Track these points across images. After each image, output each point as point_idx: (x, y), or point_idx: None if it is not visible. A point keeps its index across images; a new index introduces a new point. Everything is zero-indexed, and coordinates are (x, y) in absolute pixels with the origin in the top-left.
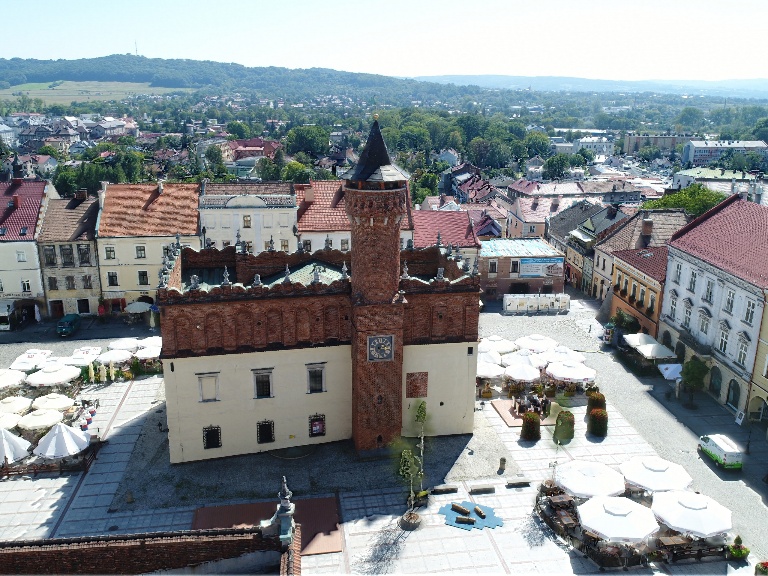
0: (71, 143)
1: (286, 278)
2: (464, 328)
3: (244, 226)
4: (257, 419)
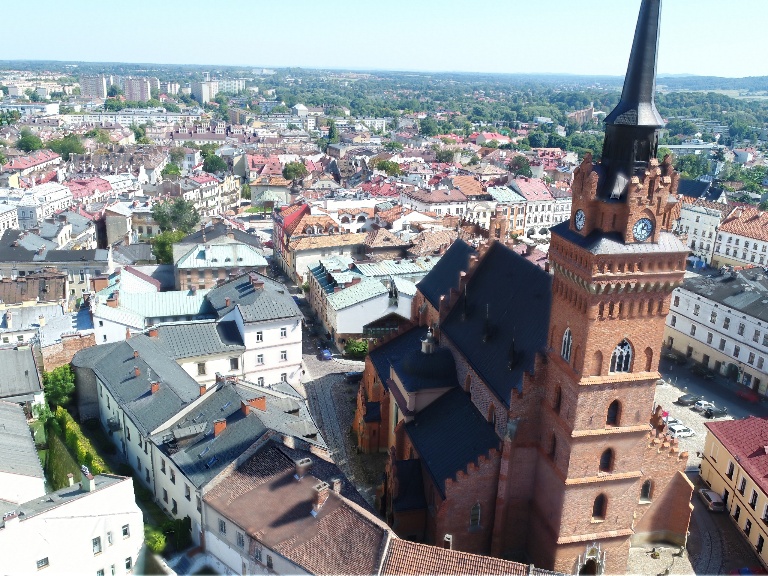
0: None
1: None
2: None
3: (697, 221)
4: None
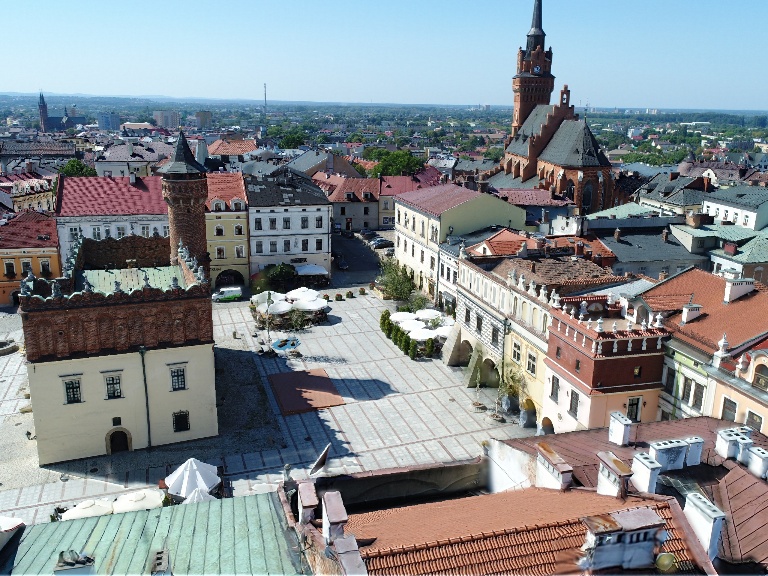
0: None
1: None
2: None
3: None
4: None
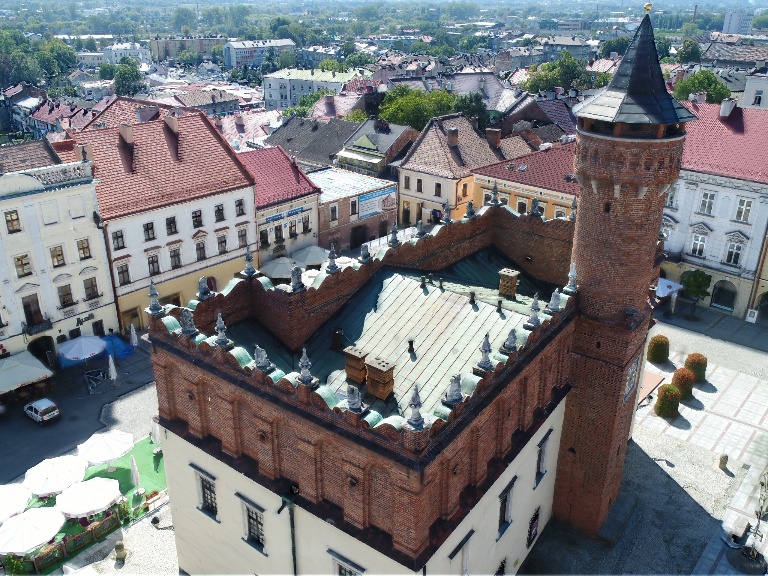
0: None
1: (535, 319)
2: None
3: (8, 231)
4: (494, 569)
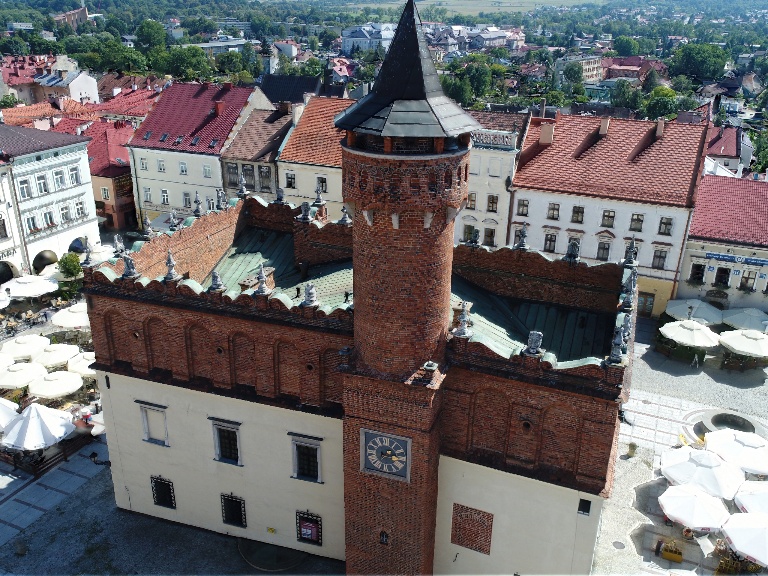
0: (447, 52)
1: (259, 287)
2: (576, 459)
3: None
4: (221, 488)
